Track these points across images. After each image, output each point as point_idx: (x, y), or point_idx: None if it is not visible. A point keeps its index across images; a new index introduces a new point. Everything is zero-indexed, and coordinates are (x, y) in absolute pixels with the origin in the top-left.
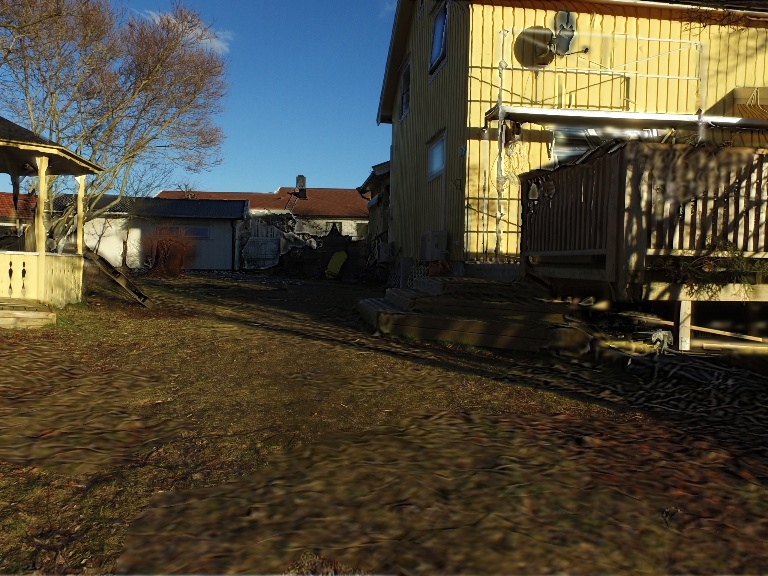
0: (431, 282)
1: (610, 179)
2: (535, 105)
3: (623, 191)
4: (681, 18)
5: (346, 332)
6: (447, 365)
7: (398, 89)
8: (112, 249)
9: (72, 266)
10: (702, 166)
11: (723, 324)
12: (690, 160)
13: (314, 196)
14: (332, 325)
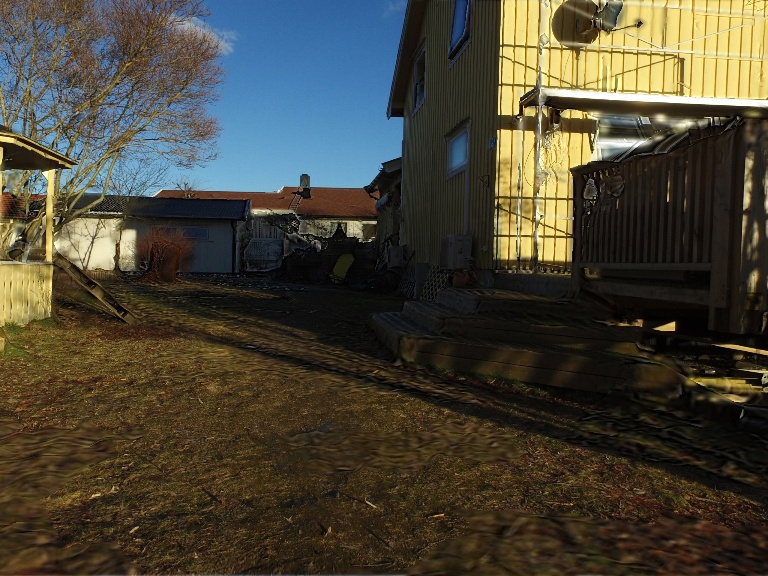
0: (459, 296)
1: (714, 171)
2: None
3: (741, 187)
4: None
5: (360, 359)
6: (496, 414)
7: (411, 79)
8: (106, 251)
9: (38, 276)
10: None
11: None
12: None
13: (319, 195)
14: (342, 348)
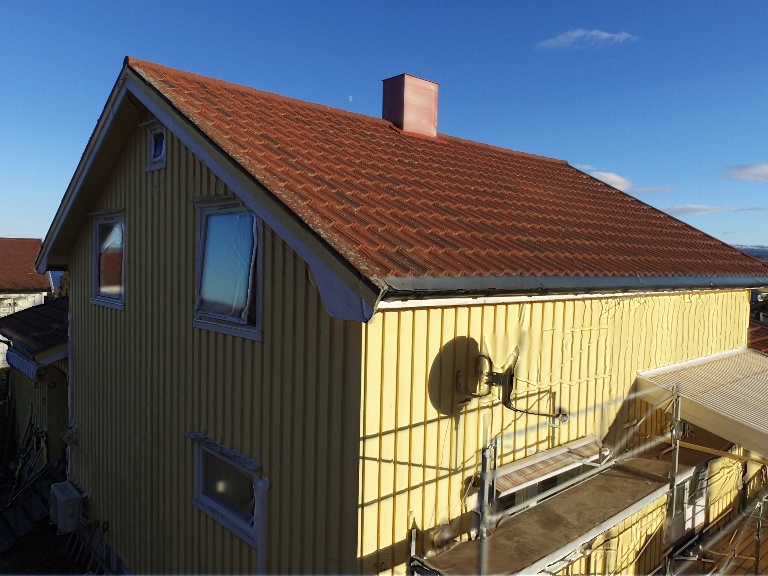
0: None
1: None
2: (454, 475)
3: None
4: None
5: None
6: None
7: (86, 239)
8: None
9: None
10: None
11: None
12: None
13: None
14: None
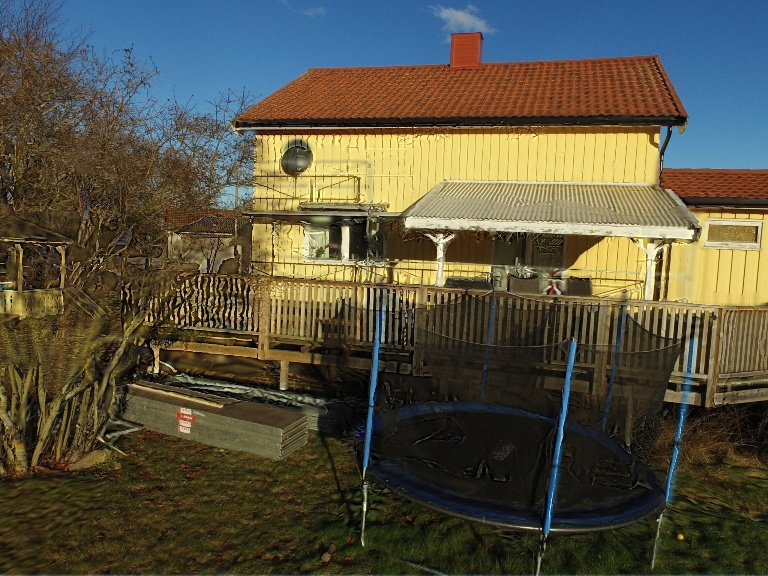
0: None
1: None
2: (295, 200)
3: None
4: (398, 132)
5: None
6: None
7: None
8: None
9: (53, 295)
10: (157, 281)
11: (170, 361)
12: (152, 278)
13: None
14: None
